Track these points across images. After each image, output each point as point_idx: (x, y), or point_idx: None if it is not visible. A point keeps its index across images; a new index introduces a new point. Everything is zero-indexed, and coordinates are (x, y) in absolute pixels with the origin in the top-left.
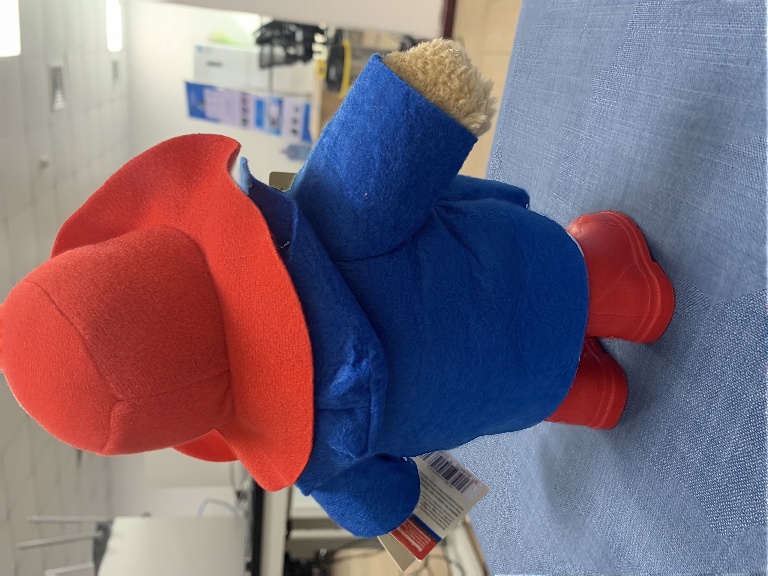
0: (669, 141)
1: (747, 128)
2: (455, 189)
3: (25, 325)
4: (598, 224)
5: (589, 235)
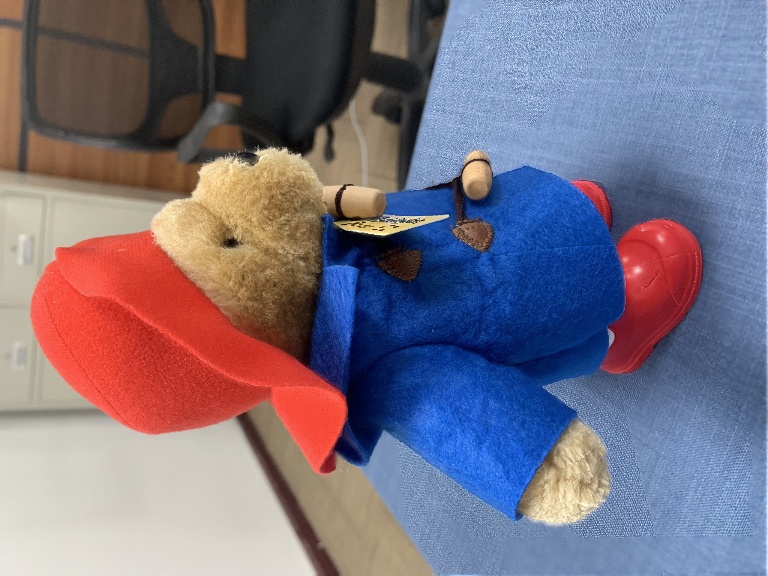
0: (767, 358)
1: (761, 464)
2: (545, 351)
3: (87, 398)
4: (666, 294)
5: (643, 307)
